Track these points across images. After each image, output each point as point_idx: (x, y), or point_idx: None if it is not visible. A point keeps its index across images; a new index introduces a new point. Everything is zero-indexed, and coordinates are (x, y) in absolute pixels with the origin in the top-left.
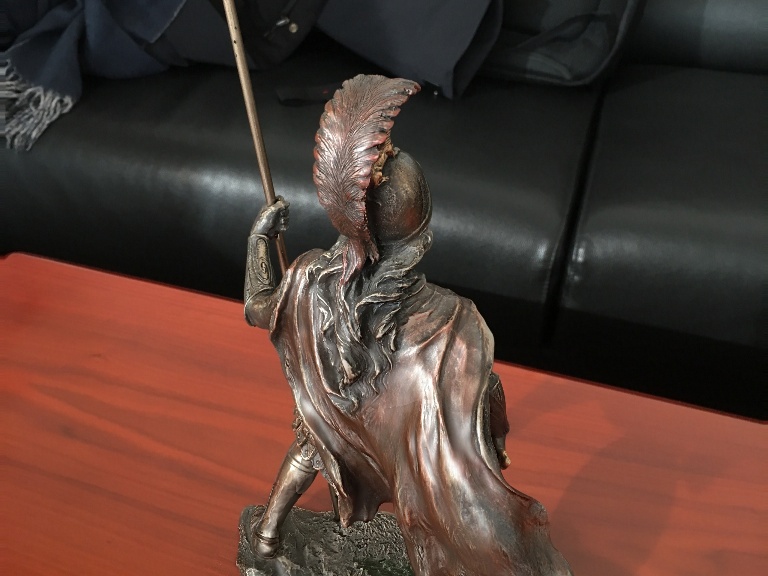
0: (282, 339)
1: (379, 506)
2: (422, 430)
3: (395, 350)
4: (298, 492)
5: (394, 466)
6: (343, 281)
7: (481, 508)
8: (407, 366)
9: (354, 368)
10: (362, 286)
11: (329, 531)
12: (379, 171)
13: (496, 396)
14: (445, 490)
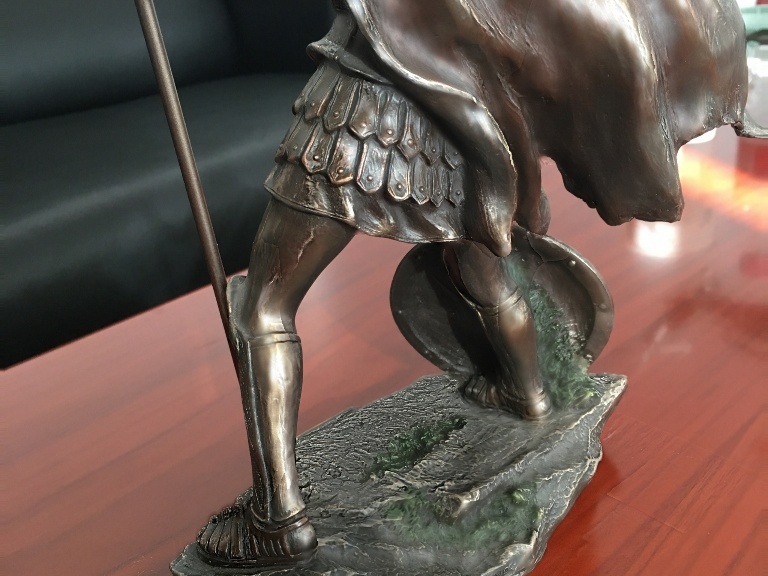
0: None
1: None
2: None
3: None
4: None
5: (615, 2)
6: None
7: None
8: None
9: None
10: None
11: None
12: None
13: None
14: None
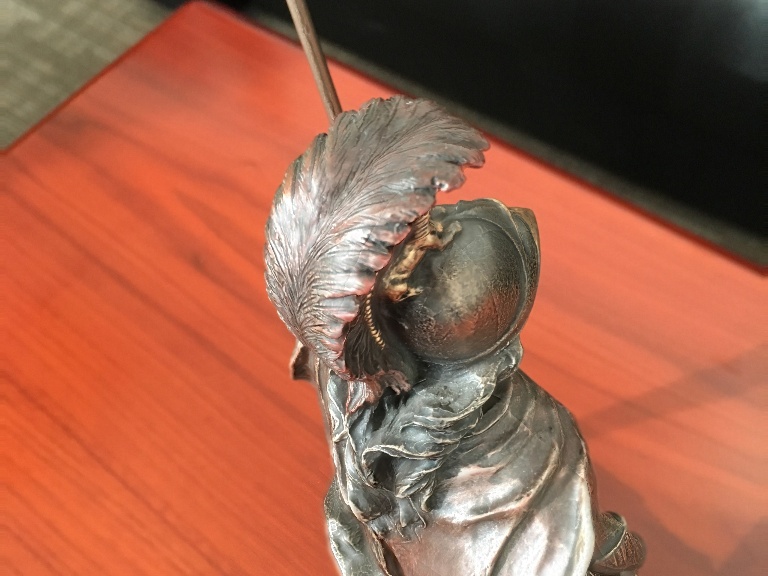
0: None
1: None
2: None
3: (430, 510)
4: None
5: None
6: (347, 409)
7: None
8: (448, 533)
9: (367, 512)
10: (384, 414)
11: None
12: (400, 282)
13: (610, 563)
14: None
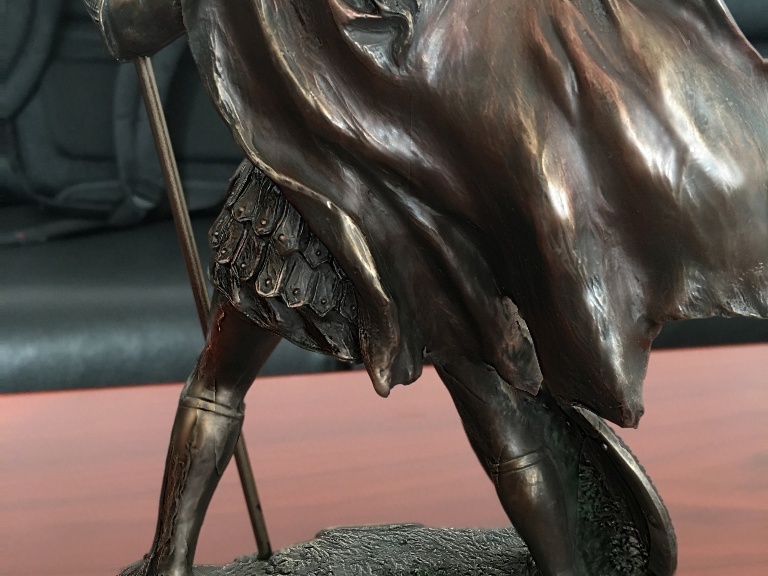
0: (204, 10)
1: (422, 350)
2: (566, 3)
3: None
4: (218, 465)
5: (516, 117)
6: None
7: (726, 99)
8: None
9: None
10: None
11: (259, 575)
12: None
13: None
14: (651, 88)
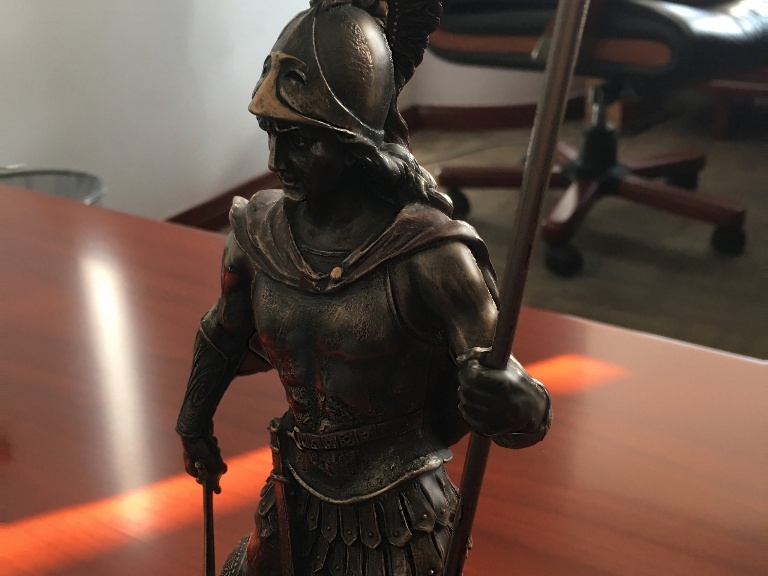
0: None
1: None
2: None
3: None
4: None
5: None
6: None
7: None
8: None
9: None
10: None
11: None
12: None
13: None
14: None
